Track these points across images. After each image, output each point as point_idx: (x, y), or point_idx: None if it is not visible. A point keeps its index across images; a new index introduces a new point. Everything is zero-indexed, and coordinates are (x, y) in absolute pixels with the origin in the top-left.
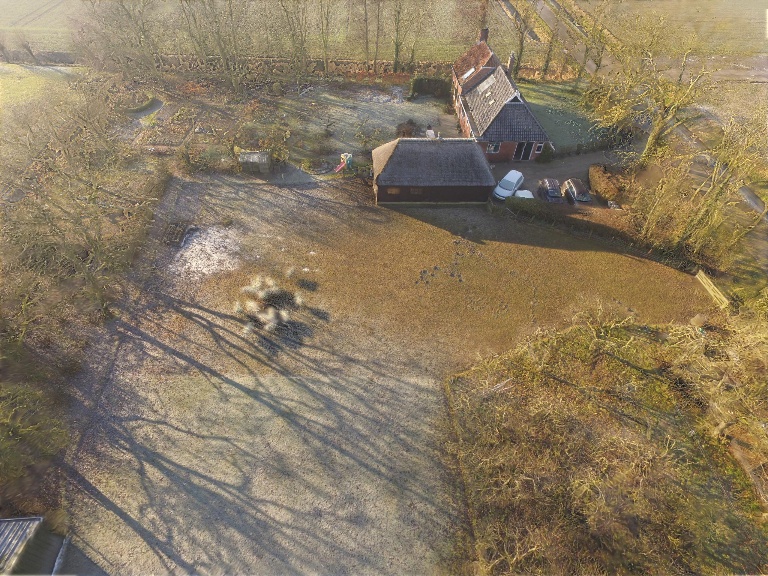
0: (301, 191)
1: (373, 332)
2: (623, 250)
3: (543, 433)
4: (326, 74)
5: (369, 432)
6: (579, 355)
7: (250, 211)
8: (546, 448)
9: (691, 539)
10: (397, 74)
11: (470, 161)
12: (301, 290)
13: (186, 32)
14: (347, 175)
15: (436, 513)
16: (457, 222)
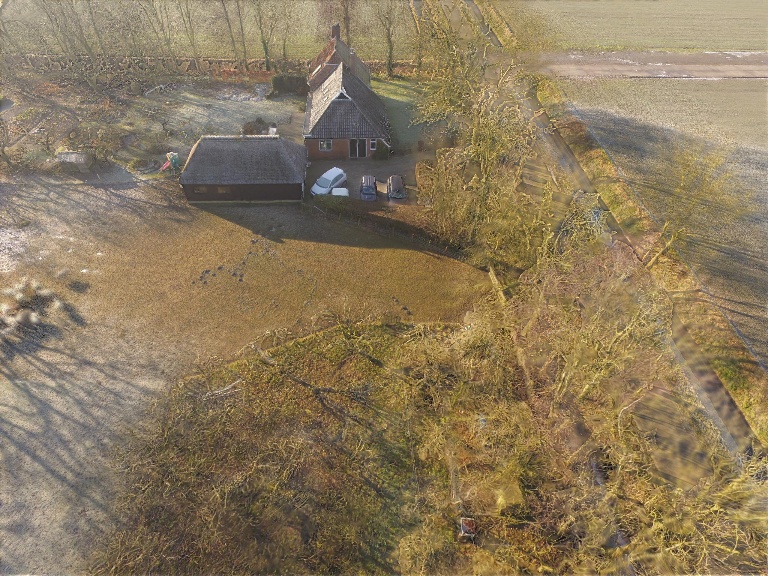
0: (116, 191)
1: (124, 334)
2: (425, 247)
3: (213, 436)
4: (198, 73)
5: (72, 437)
6: (330, 355)
7: (53, 212)
8: (213, 452)
9: (333, 544)
10: (262, 72)
11: (275, 159)
12: (69, 292)
13: (50, 32)
14: (170, 174)
15: (104, 520)
16: (264, 221)
